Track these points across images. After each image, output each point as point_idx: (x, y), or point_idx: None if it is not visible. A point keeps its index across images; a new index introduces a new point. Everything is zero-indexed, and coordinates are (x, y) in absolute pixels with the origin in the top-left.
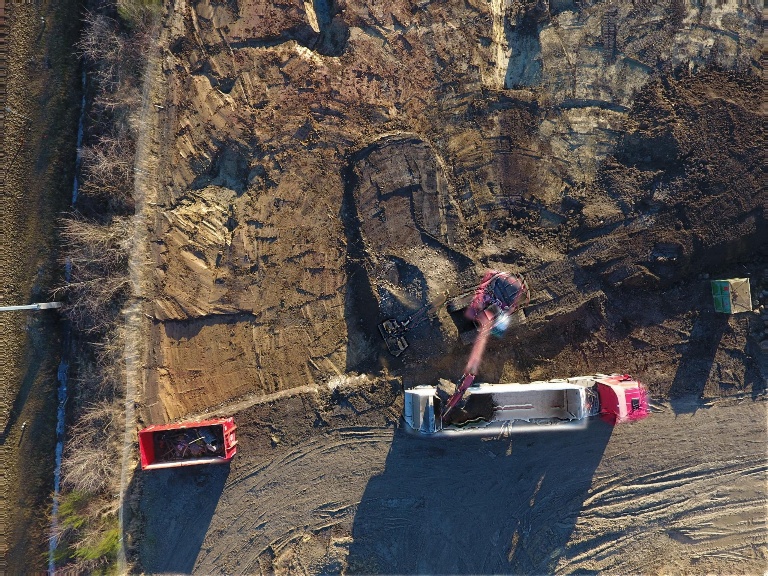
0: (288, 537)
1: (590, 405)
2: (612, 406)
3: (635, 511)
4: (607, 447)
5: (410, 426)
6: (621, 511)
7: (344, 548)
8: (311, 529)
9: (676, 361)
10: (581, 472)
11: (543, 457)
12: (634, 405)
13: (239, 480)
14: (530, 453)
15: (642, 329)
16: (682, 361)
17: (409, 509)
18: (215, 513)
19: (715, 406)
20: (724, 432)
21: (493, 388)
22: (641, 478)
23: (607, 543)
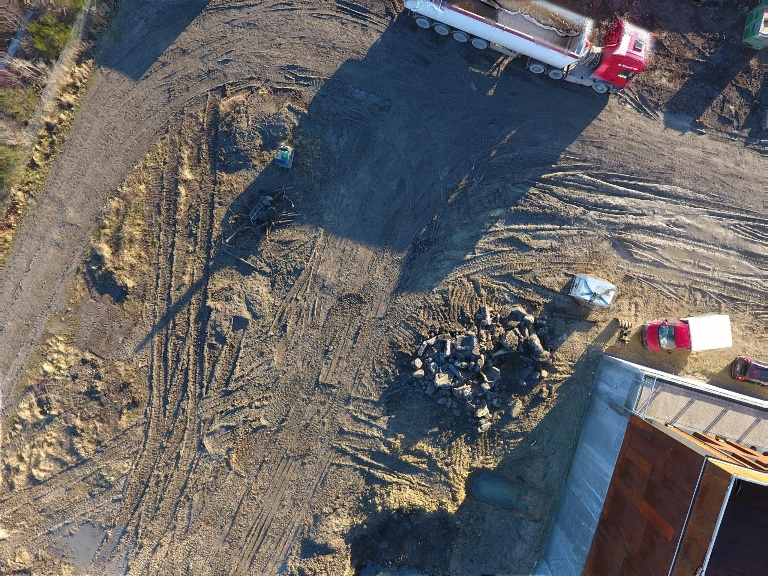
0: (246, 83)
1: (590, 59)
2: (613, 50)
3: (589, 205)
4: (587, 128)
5: (408, 11)
6: (576, 198)
7: (295, 116)
8: (271, 85)
9: (685, 76)
10: (552, 144)
11: (522, 112)
12: (636, 47)
13: (222, 7)
14: (511, 102)
15: (665, 31)
16: (691, 79)
17: (373, 107)
18: (185, 30)
19: (706, 136)
20: (705, 163)
21: (502, 8)
22: (608, 175)
23: (550, 225)
